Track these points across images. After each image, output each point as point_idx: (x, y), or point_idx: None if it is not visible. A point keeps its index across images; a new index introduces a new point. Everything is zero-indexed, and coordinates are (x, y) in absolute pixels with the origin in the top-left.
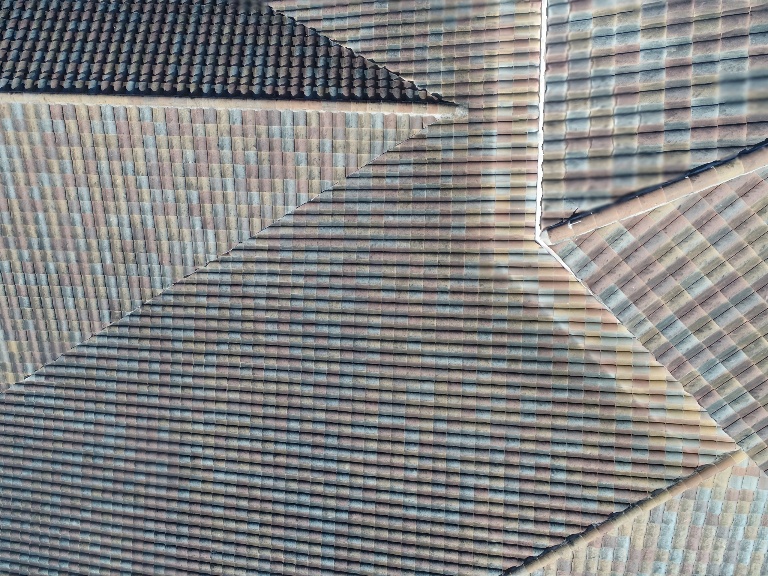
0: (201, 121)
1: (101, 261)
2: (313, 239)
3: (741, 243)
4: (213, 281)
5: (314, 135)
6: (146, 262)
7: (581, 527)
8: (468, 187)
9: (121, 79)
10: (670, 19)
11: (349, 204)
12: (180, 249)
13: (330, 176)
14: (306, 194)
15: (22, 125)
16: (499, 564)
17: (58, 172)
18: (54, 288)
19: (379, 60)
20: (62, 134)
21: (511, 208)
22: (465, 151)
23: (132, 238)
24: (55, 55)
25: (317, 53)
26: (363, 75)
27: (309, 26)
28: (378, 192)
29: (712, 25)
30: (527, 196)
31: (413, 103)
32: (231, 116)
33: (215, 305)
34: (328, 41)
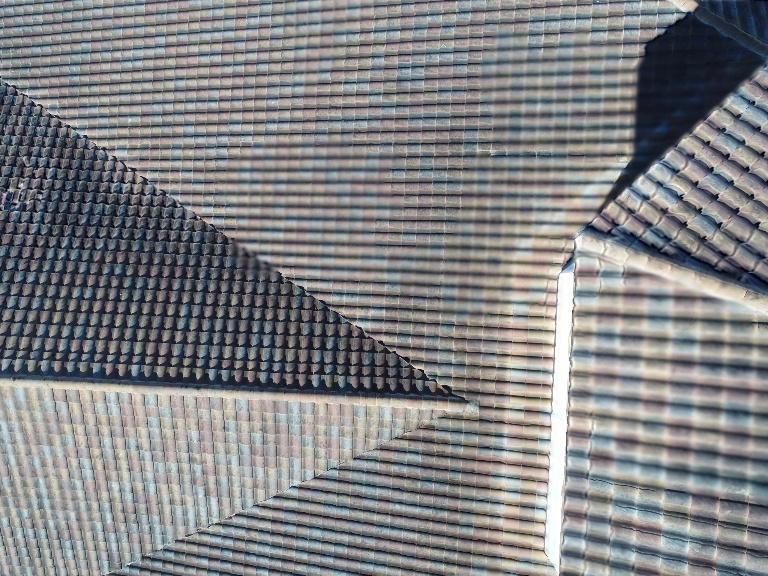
0: (207, 408)
1: (102, 520)
2: (318, 516)
3: None
4: (215, 544)
5: (321, 423)
6: (147, 522)
7: None
8: (477, 486)
9: (126, 362)
10: (694, 515)
11: (355, 486)
12: (182, 512)
13: (337, 457)
14: (312, 471)
15: (24, 405)
16: None
17: (60, 445)
18: (53, 541)
19: (389, 343)
20: (65, 414)
21: (520, 514)
22: (475, 449)
23: (134, 502)
24: (60, 329)
25: (326, 331)
26: (373, 360)
27: (319, 298)
28: (385, 478)
29: (737, 537)
30: (537, 504)
31: (423, 400)
32: (237, 404)
33: (216, 568)
34: (338, 317)
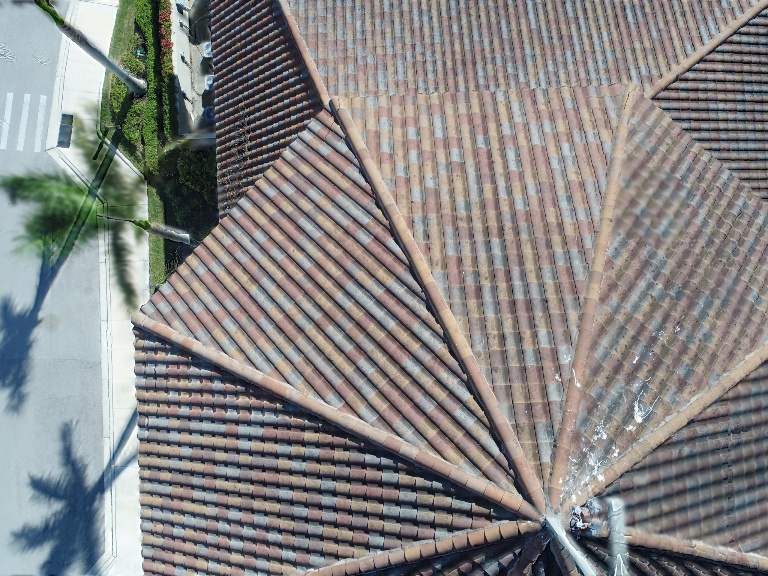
0: None
1: None
2: None
3: (766, 284)
4: None
5: None
6: None
7: (670, 89)
8: None
9: None
10: None
11: None
12: None
13: None
14: None
15: None
16: (717, 56)
17: None
18: None
19: None
20: None
21: None
22: None
23: None
24: None
25: None
26: None
27: None
28: None
29: None
30: None
31: None
32: None
33: None
34: None
